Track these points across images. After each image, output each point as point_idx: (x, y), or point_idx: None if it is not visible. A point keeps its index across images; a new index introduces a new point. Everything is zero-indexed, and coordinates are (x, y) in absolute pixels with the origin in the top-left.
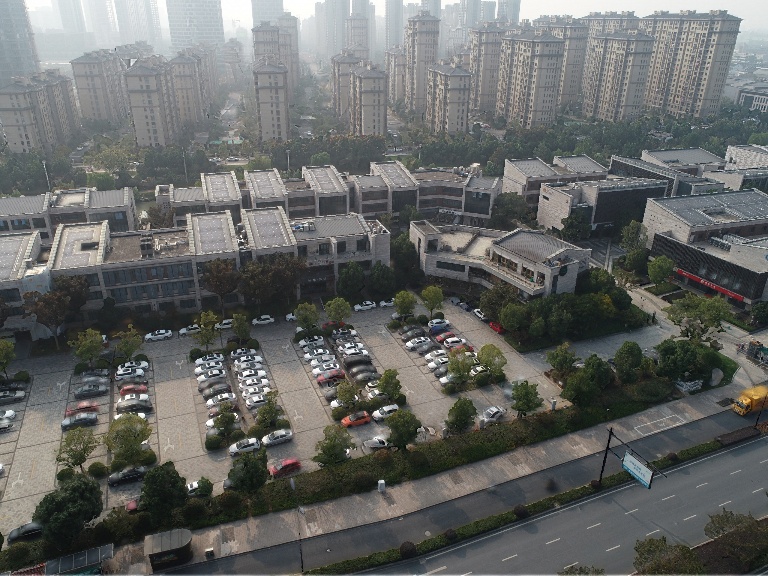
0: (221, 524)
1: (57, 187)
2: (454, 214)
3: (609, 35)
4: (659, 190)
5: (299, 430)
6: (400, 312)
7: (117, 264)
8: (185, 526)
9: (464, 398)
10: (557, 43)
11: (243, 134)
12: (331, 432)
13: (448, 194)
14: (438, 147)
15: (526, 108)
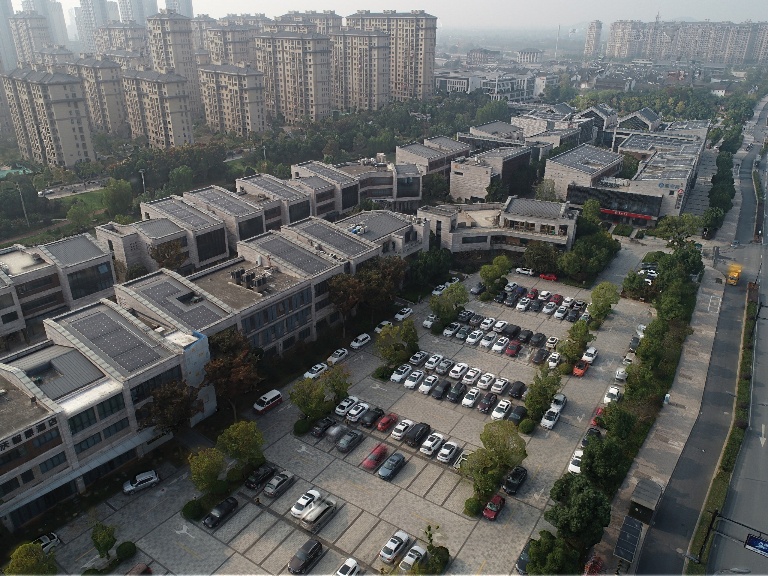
0: (627, 473)
1: None
2: (386, 202)
3: (346, 32)
4: (528, 154)
5: (557, 392)
6: (490, 284)
7: (253, 307)
8: None
9: None
10: (325, 40)
11: (14, 162)
12: (637, 369)
13: (377, 184)
14: (272, 147)
15: (305, 103)
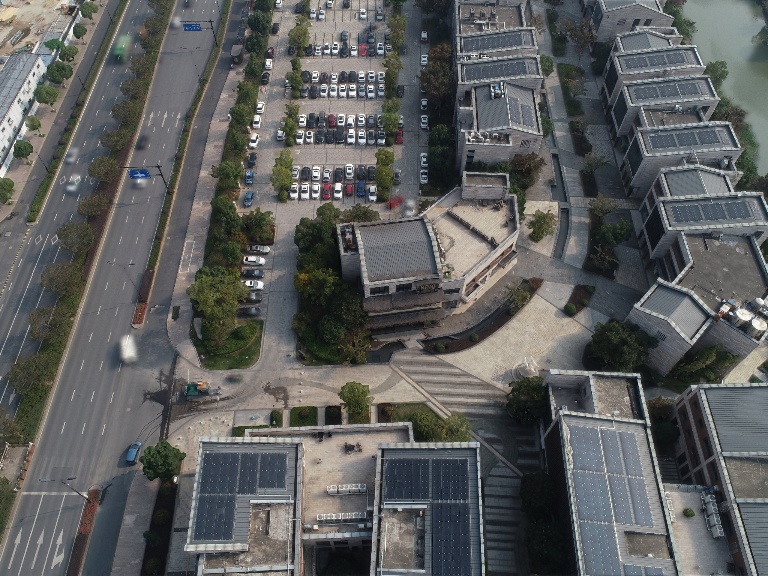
0: None
1: None
2: None
3: None
4: None
5: None
6: None
7: None
8: None
9: (239, 137)
10: None
11: None
12: None
13: None
14: None
15: None
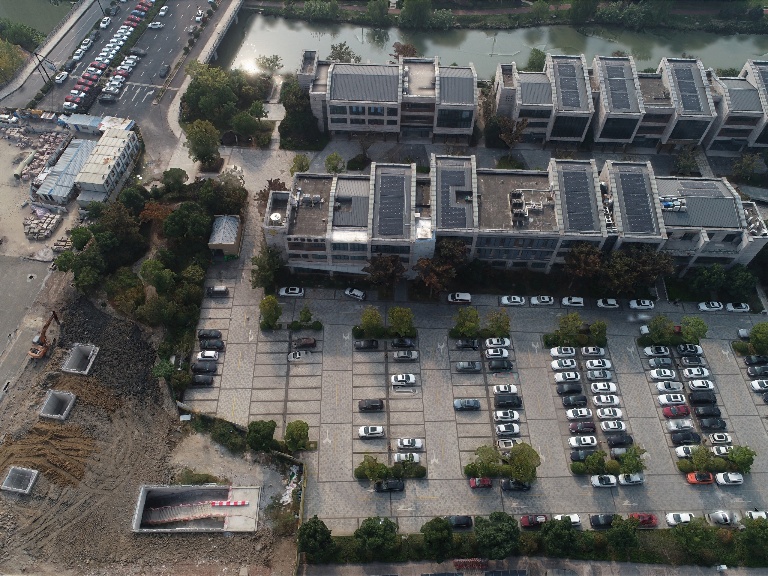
0: (591, 560)
1: (374, 2)
2: None
3: None
4: None
5: (648, 472)
6: (755, 342)
7: (492, 233)
8: (566, 555)
9: None
10: None
11: None
12: (699, 527)
13: None
14: None
15: None
